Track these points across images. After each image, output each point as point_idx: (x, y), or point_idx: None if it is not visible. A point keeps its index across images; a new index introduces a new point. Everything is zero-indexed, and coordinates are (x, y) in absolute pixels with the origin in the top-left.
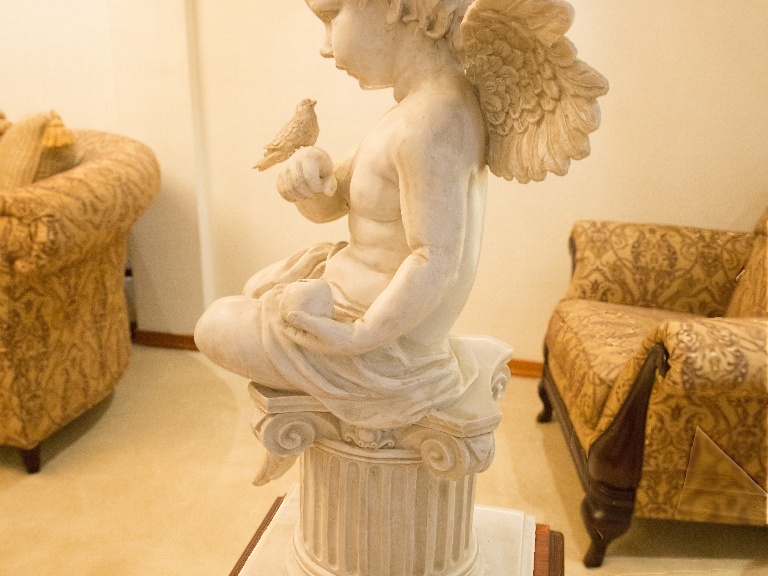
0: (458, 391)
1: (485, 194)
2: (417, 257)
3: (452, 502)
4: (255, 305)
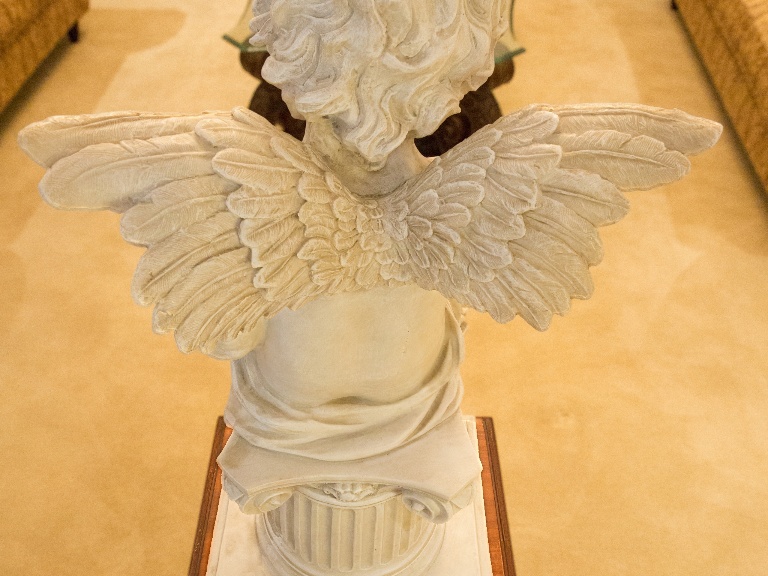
0: (255, 441)
1: (311, 313)
2: None
3: (297, 518)
4: None
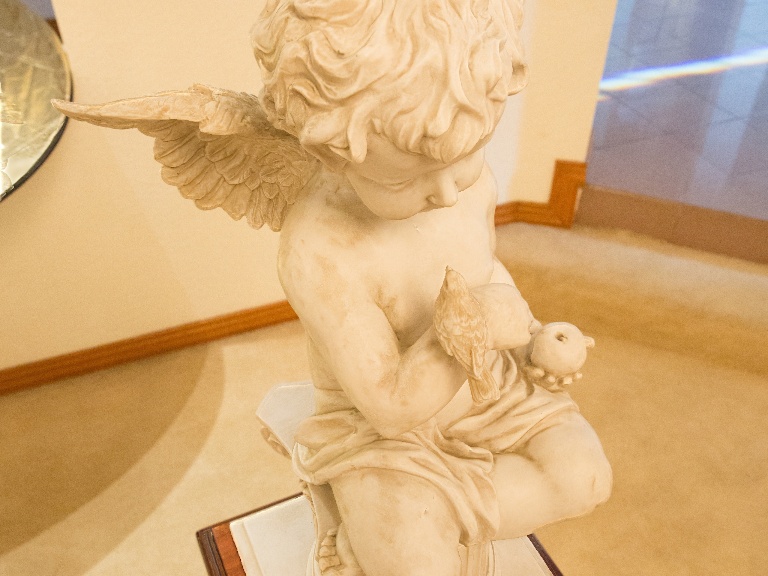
0: None
1: None
2: (495, 259)
3: None
4: (569, 417)
